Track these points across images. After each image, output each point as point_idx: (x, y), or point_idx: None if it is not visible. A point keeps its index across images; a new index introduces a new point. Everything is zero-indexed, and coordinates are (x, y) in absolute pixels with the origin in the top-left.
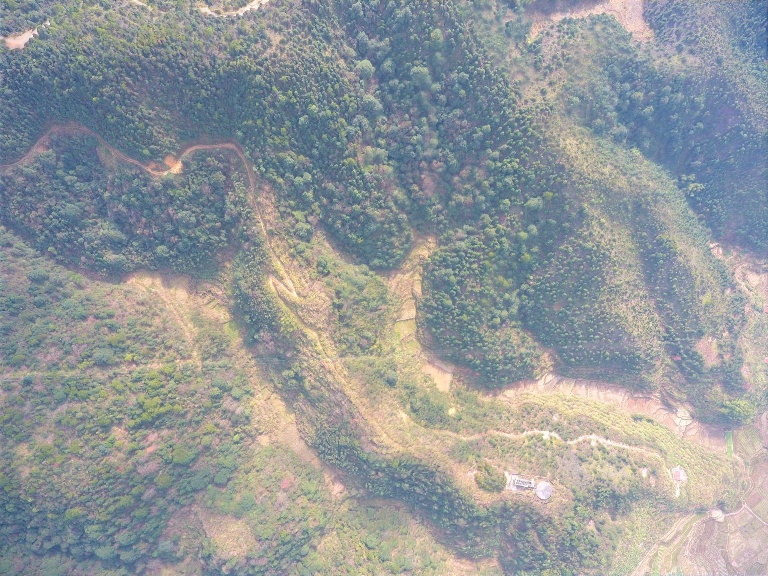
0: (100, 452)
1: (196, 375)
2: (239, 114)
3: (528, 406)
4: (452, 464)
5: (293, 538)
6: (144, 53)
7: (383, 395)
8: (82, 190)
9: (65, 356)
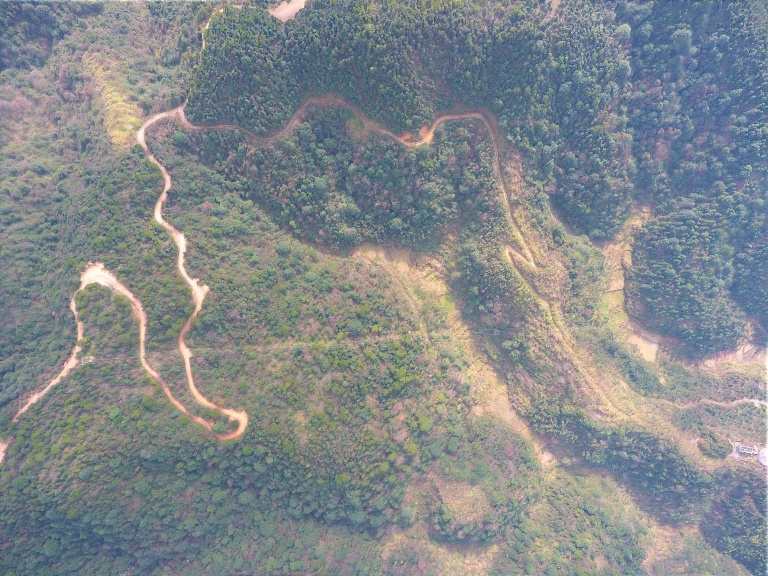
0: (362, 420)
1: (428, 346)
2: (502, 82)
3: (733, 375)
4: (675, 432)
5: (518, 504)
6: (428, 20)
7: (606, 364)
8: (328, 163)
9: (323, 327)
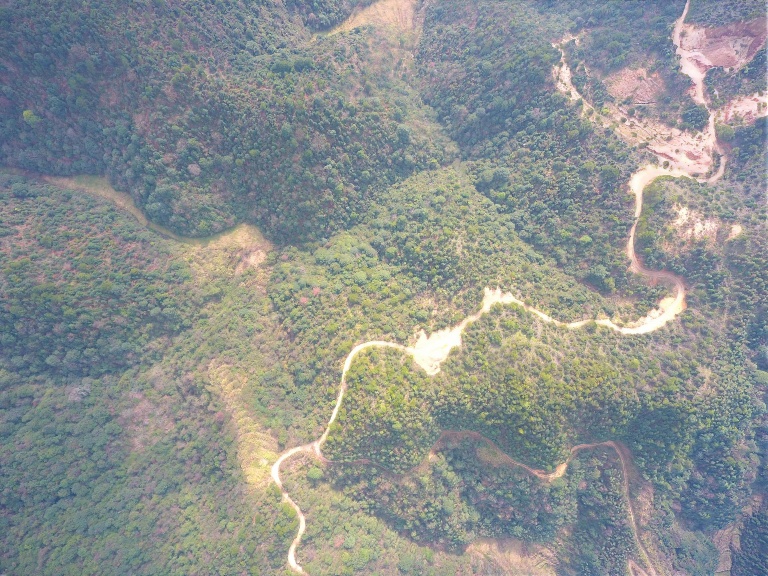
0: None
1: None
2: (644, 432)
3: None
4: None
5: None
6: (584, 396)
7: None
8: (456, 483)
9: None
